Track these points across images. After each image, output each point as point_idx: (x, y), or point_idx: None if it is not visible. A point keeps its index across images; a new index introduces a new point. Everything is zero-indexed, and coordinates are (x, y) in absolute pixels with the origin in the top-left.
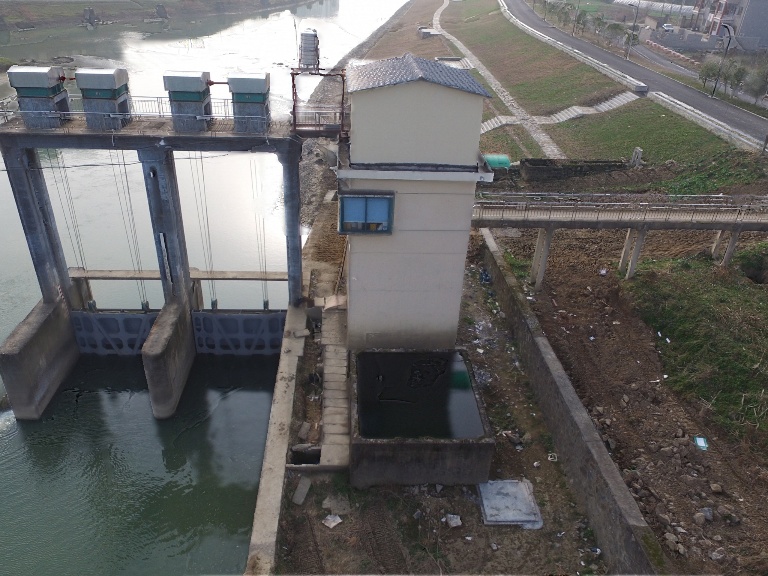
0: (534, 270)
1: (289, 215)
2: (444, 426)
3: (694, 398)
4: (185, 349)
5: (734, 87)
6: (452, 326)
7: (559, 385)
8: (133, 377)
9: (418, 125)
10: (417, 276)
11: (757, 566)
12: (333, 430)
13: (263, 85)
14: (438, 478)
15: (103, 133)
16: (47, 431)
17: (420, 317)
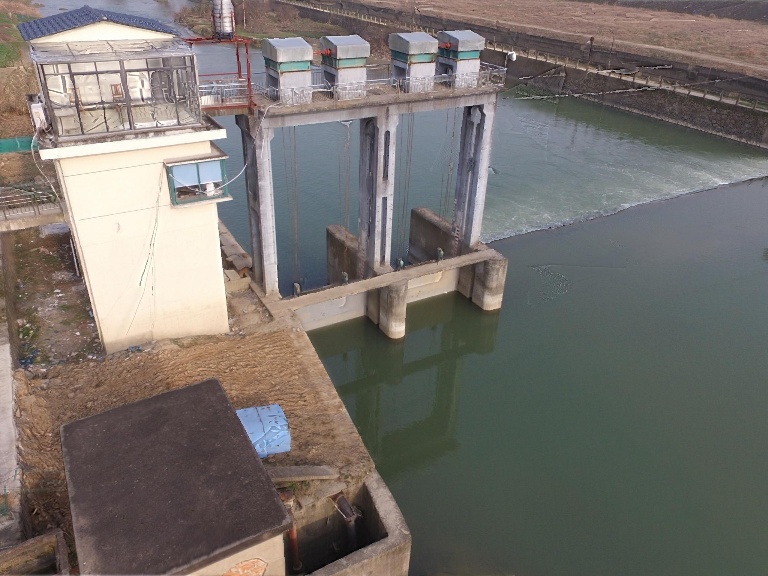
0: None
1: None
2: None
3: None
4: None
5: None
6: None
7: None
8: None
9: None
10: None
11: None
12: None
13: None
14: None
15: None
16: None
17: None
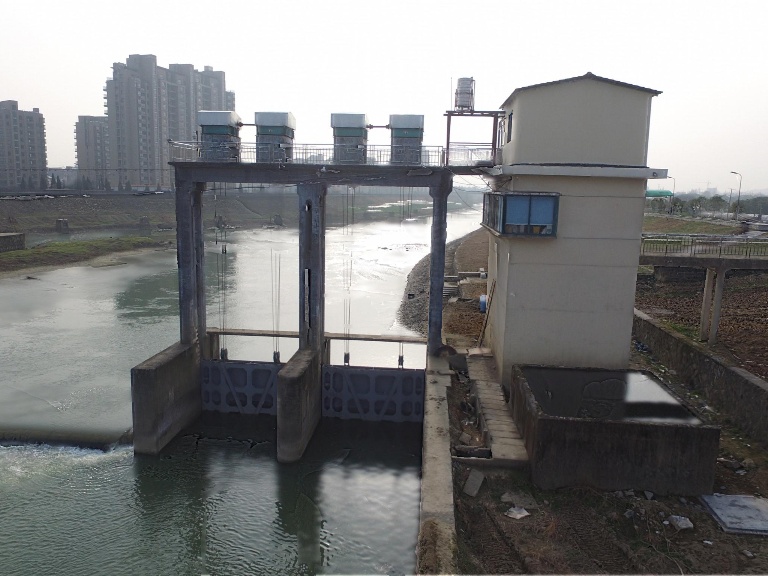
0: (704, 325)
1: (436, 252)
2: None
3: None
4: (314, 399)
5: None
6: (623, 359)
7: None
8: (256, 429)
9: (584, 124)
10: (582, 293)
11: None
12: (502, 434)
13: (421, 120)
14: (646, 482)
15: (271, 162)
16: (163, 467)
17: (585, 345)
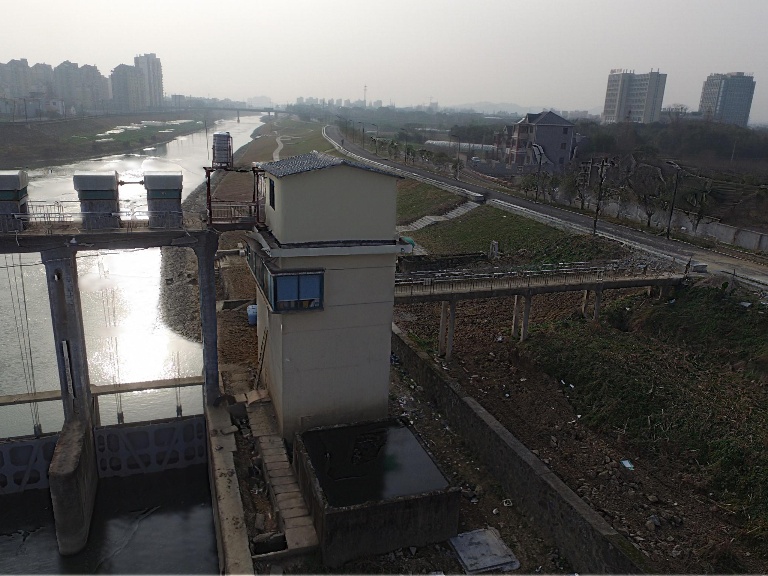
0: (442, 343)
1: (207, 309)
2: (406, 487)
3: (609, 428)
4: (90, 471)
5: (551, 193)
6: (383, 399)
7: (498, 433)
8: (25, 515)
9: (342, 205)
10: (348, 351)
11: (711, 553)
12: (292, 514)
13: (180, 181)
14: (411, 540)
15: (4, 235)
16: None
17: (353, 393)
